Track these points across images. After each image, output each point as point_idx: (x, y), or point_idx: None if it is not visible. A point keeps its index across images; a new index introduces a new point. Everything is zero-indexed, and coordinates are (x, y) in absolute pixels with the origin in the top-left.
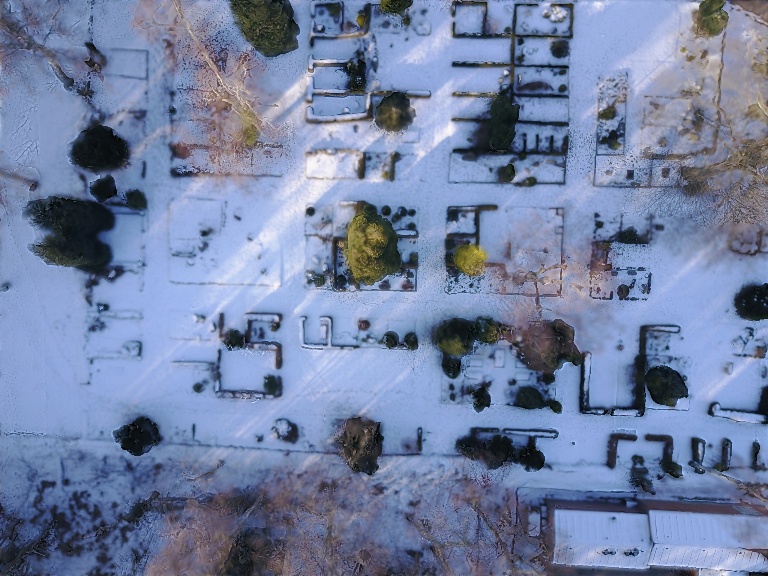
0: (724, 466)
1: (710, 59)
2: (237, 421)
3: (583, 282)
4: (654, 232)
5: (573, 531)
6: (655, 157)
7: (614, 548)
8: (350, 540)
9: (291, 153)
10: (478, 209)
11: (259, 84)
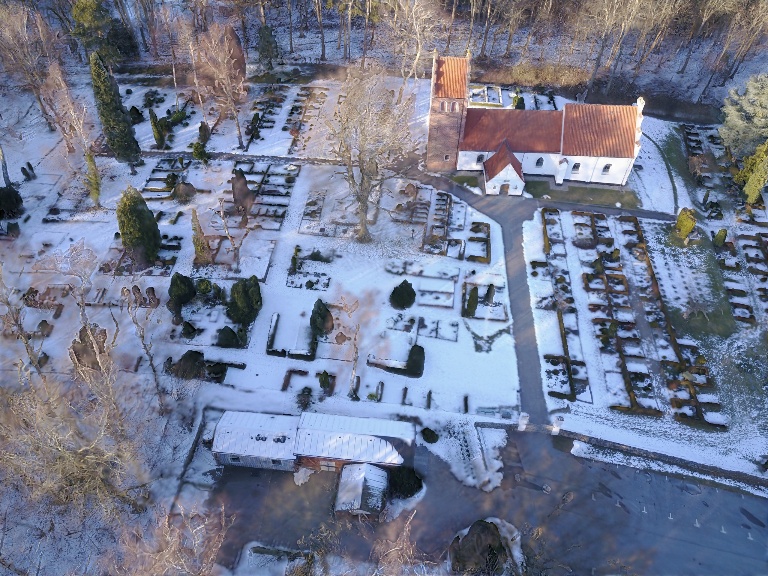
0: None
1: None
2: (6, 355)
3: (283, 278)
4: (335, 258)
5: (234, 421)
6: (339, 224)
7: (265, 433)
8: None
9: None
10: (222, 237)
11: (116, 187)
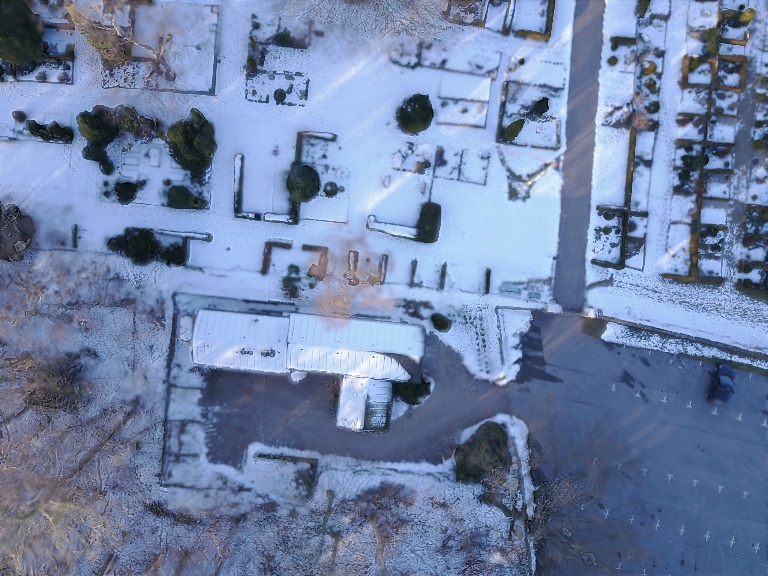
0: (378, 279)
1: None
2: None
3: (239, 84)
4: (313, 38)
5: (212, 329)
6: None
7: (250, 347)
8: (13, 341)
9: None
10: (131, 1)
11: None
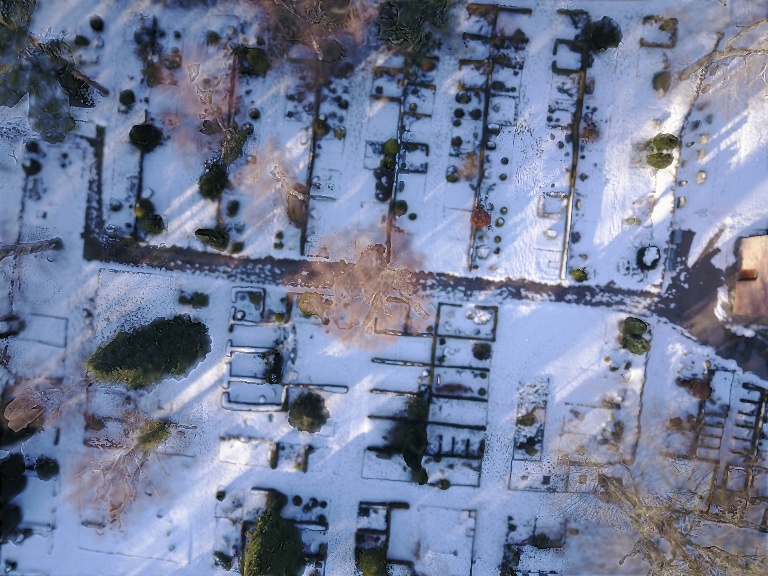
0: None
1: (633, 372)
2: None
3: None
4: (568, 536)
5: None
6: (573, 464)
7: None
8: None
9: (205, 435)
10: (389, 508)
11: None
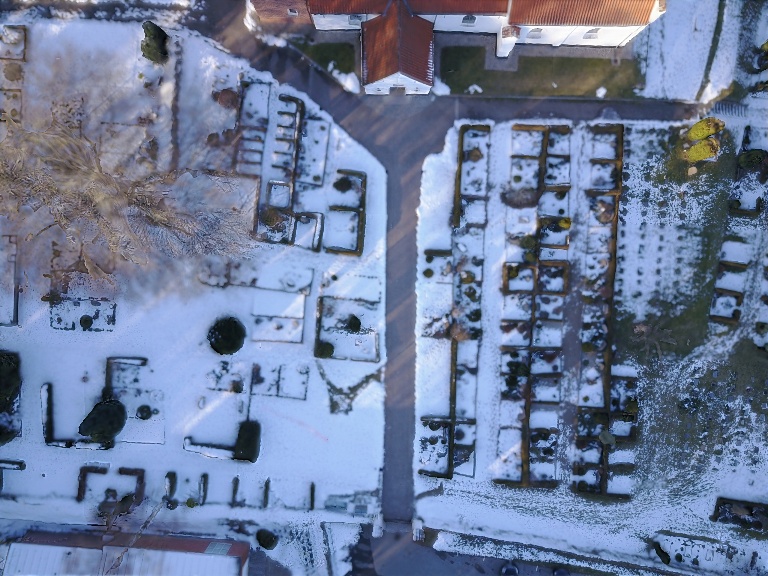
0: (197, 502)
1: (164, 86)
2: None
3: (44, 312)
4: (118, 262)
5: (23, 566)
6: None
7: None
8: None
9: None
10: None
11: None
